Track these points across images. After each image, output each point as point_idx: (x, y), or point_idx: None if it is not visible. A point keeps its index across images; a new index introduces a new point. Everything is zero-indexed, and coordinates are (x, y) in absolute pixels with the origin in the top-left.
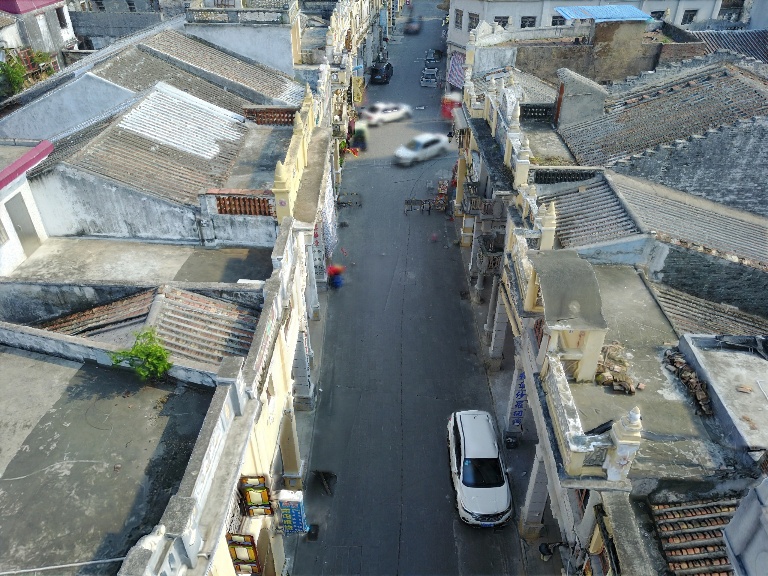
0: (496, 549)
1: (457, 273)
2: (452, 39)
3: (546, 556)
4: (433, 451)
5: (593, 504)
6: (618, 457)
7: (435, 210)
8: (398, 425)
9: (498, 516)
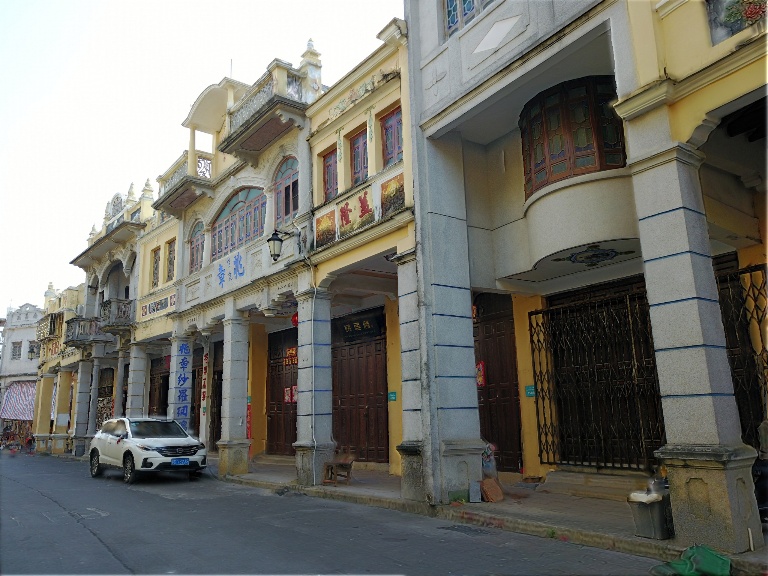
0: (198, 487)
1: (53, 459)
2: (7, 372)
3: (277, 243)
4: (71, 480)
5: (304, 153)
6: (311, 80)
7: (7, 449)
8: (5, 480)
9: (192, 448)
